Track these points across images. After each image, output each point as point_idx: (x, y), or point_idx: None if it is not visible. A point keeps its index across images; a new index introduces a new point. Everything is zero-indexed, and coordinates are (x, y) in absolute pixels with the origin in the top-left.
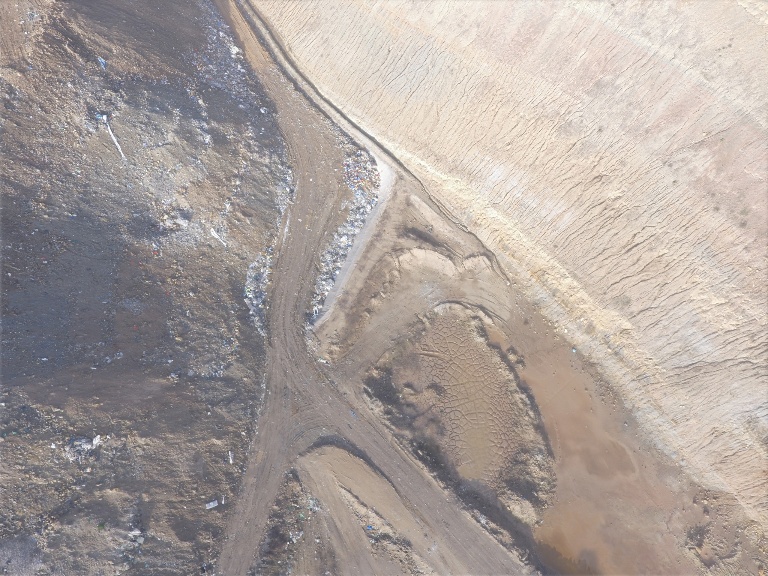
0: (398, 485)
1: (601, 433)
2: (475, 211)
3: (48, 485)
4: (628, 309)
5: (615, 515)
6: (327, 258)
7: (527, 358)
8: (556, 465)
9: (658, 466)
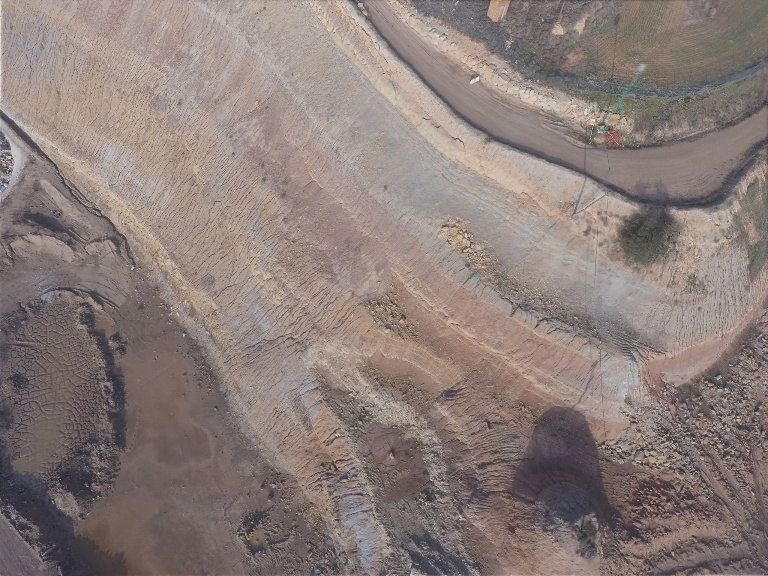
0: None
1: (186, 419)
2: (103, 194)
3: None
4: (213, 289)
5: (172, 504)
6: None
7: (130, 344)
8: (124, 454)
9: (236, 451)
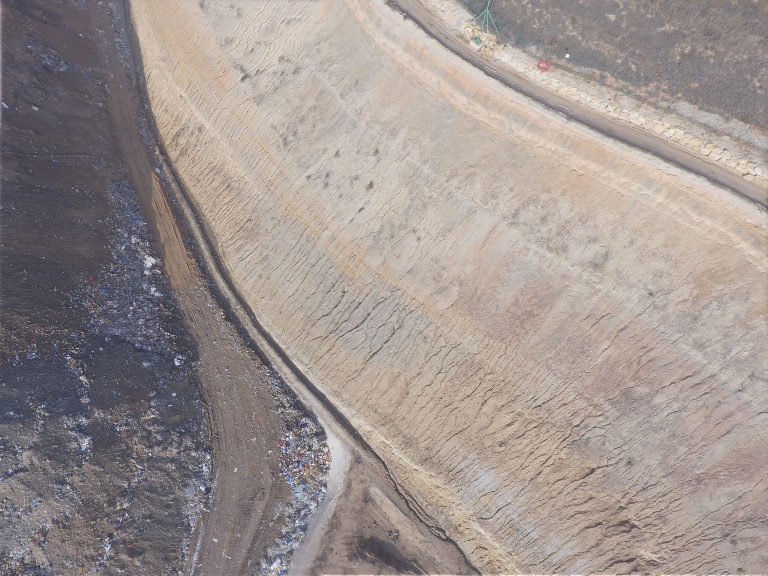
0: None
1: None
2: (455, 516)
3: None
4: None
5: None
6: None
7: None
8: None
9: None
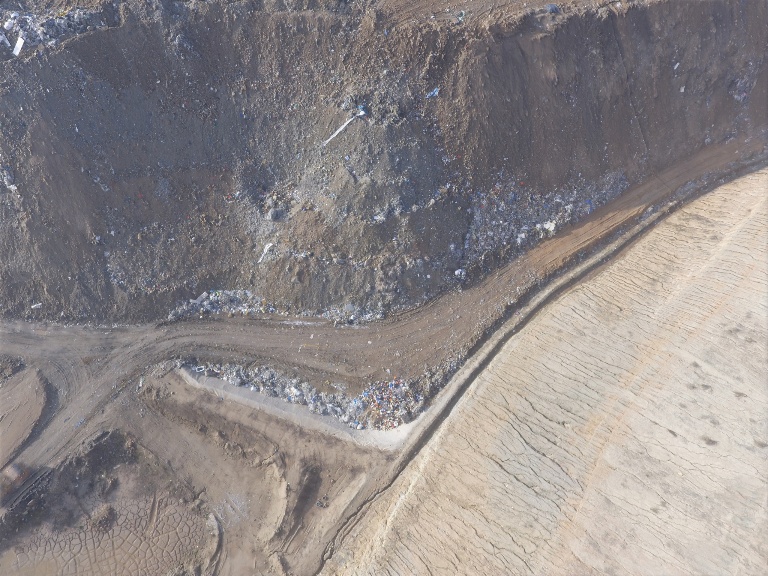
0: None
1: None
2: (346, 570)
3: None
4: None
5: None
6: (265, 374)
7: None
8: None
9: None
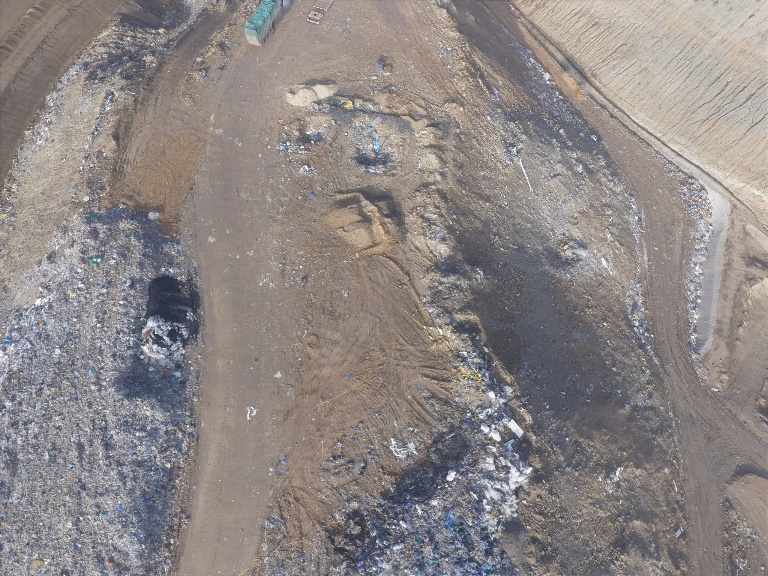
0: None
1: None
2: None
3: (606, 517)
4: None
5: None
6: (690, 287)
7: None
8: None
9: None
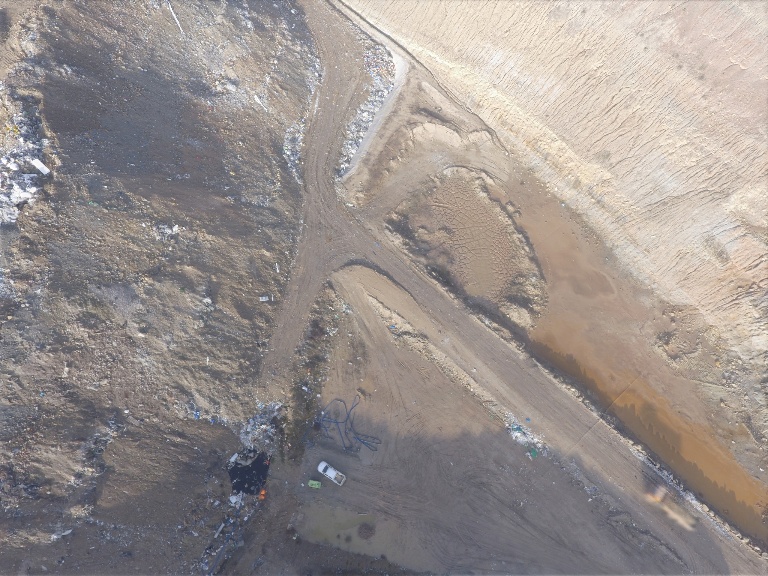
0: (416, 296)
1: (586, 265)
2: (478, 94)
3: (141, 252)
4: (608, 161)
5: (597, 323)
6: (352, 128)
7: (523, 210)
8: (548, 287)
9: (633, 289)
